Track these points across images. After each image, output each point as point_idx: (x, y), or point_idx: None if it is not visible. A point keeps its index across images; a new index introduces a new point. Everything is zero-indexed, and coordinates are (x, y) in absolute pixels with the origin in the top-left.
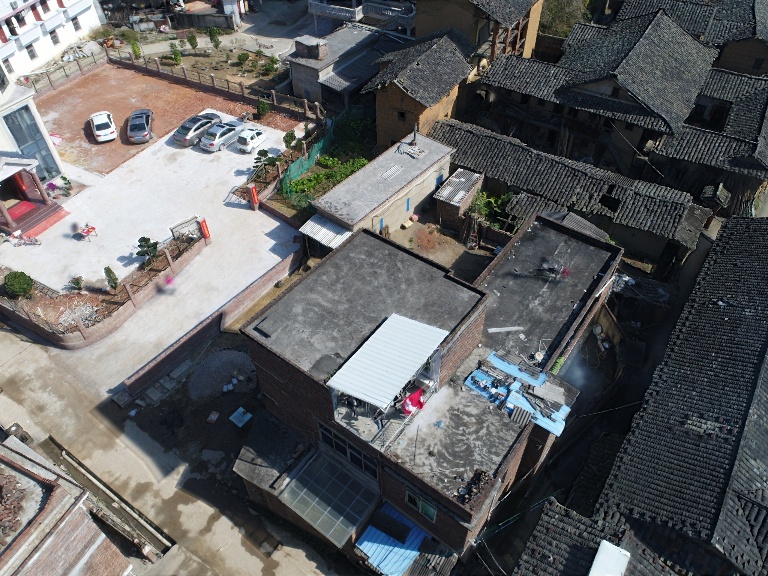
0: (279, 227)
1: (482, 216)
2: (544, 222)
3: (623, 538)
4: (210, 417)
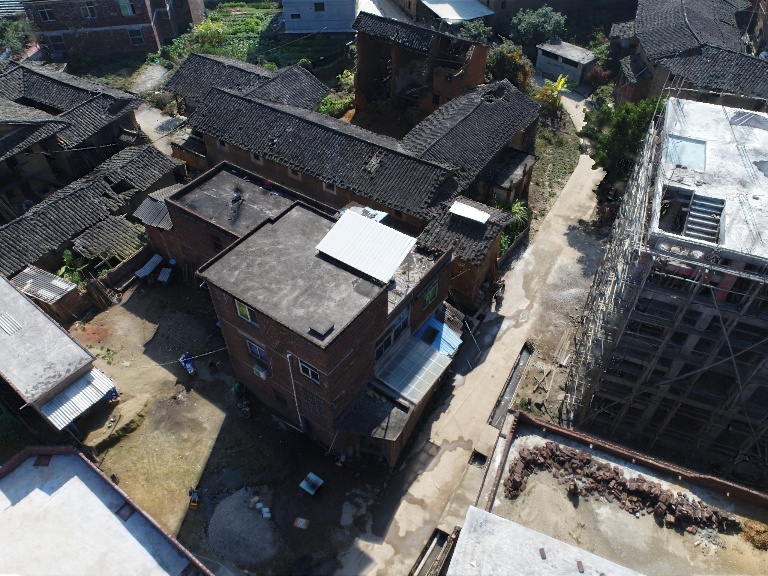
0: (5, 488)
1: (81, 284)
2: (175, 198)
3: (446, 204)
4: (301, 526)
